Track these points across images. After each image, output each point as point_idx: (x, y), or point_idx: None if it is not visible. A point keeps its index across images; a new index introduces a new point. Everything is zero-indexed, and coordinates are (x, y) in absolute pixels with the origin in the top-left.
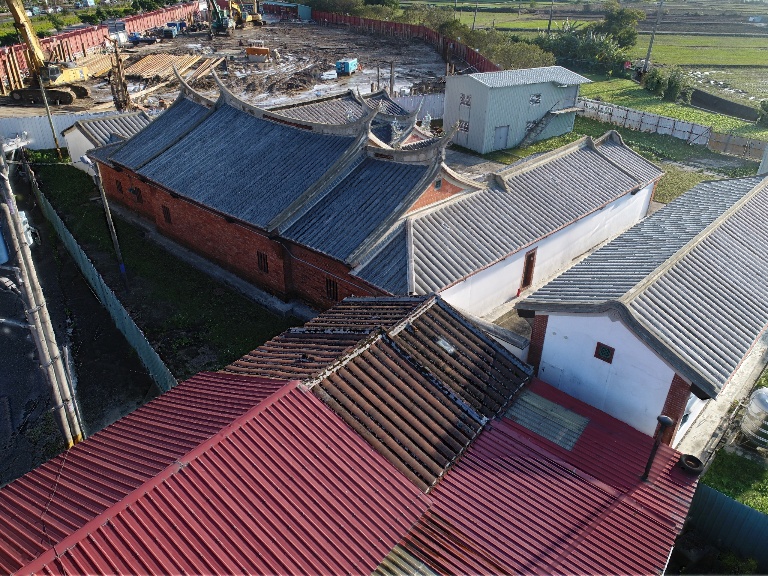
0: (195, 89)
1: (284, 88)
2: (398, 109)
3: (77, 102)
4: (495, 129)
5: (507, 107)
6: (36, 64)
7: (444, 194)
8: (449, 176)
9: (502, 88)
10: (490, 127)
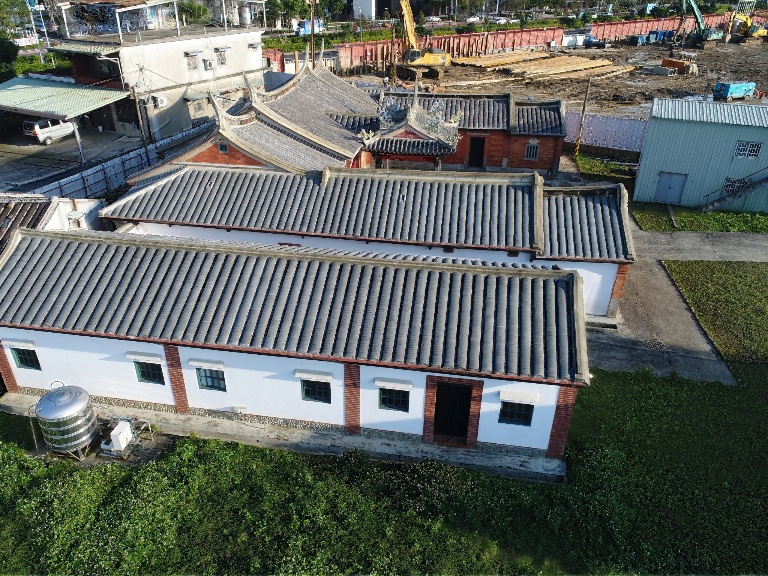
0: (528, 87)
1: (609, 99)
2: (556, 123)
3: (422, 81)
4: (659, 173)
5: (686, 149)
6: (406, 47)
7: (235, 160)
8: (235, 144)
9: (678, 121)
10: (650, 169)
